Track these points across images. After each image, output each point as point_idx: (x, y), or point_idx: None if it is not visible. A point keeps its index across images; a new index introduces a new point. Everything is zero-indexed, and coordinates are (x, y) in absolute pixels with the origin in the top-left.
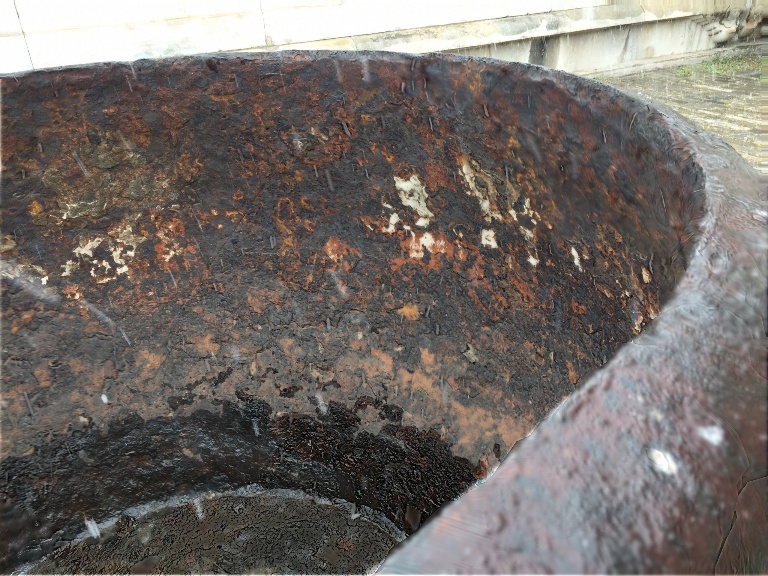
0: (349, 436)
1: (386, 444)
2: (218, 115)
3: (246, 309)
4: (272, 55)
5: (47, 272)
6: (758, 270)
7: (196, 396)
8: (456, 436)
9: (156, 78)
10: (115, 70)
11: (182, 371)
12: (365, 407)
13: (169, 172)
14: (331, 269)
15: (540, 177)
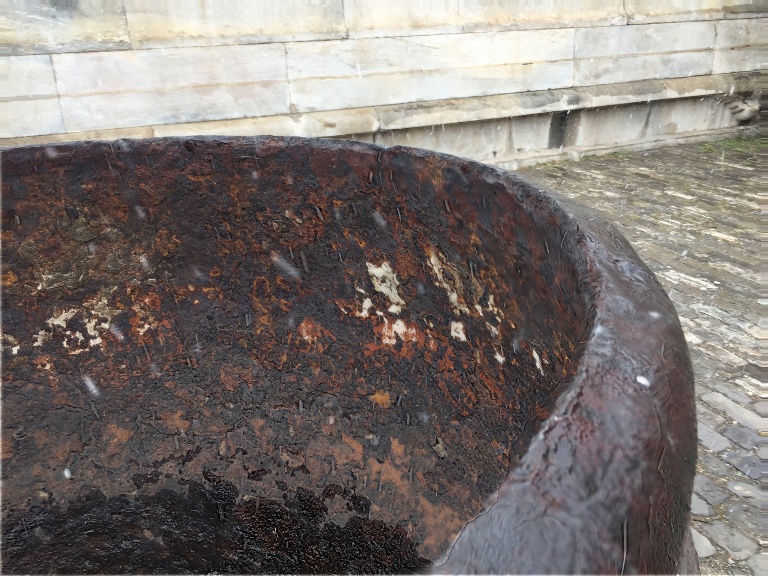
0: (315, 526)
1: (352, 538)
2: (195, 194)
3: (219, 386)
4: (247, 139)
5: (19, 341)
6: (619, 453)
7: (162, 474)
8: (422, 535)
9: (135, 157)
10: (95, 148)
11: (150, 447)
12: (333, 496)
13: (146, 247)
14: (305, 350)
15: (501, 276)
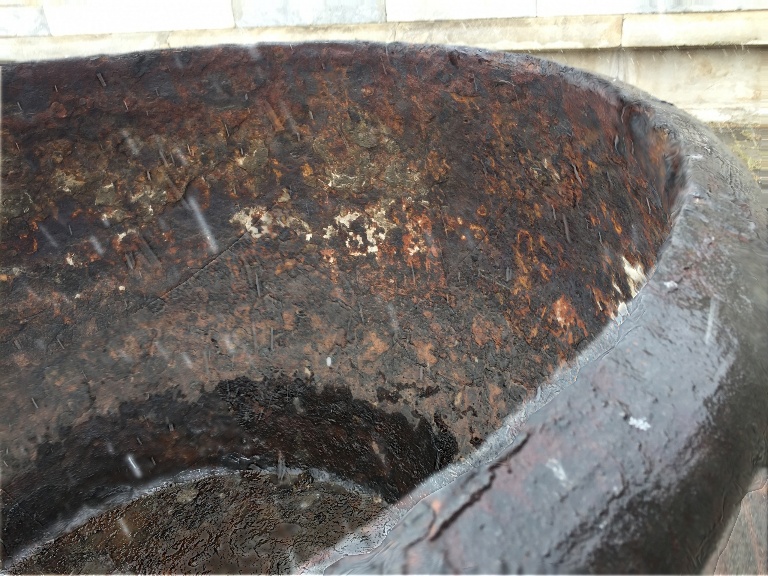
0: None
1: None
2: (461, 117)
3: (469, 334)
4: (509, 58)
5: (312, 230)
6: None
7: (401, 398)
8: None
9: (406, 64)
10: (372, 49)
11: (398, 367)
12: None
13: (420, 166)
14: (556, 333)
15: None
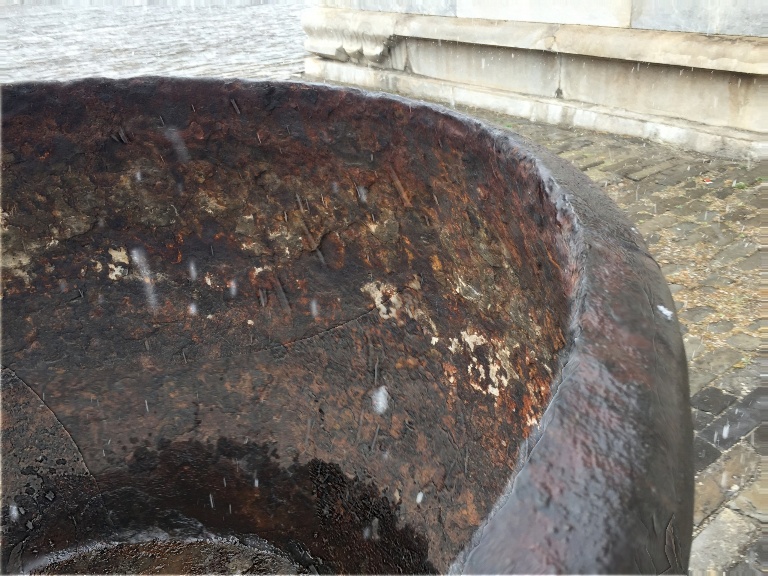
0: None
1: None
2: None
3: None
4: None
5: (439, 334)
6: None
7: None
8: None
9: (509, 174)
10: (482, 138)
11: None
12: None
13: (540, 319)
14: None
15: None
